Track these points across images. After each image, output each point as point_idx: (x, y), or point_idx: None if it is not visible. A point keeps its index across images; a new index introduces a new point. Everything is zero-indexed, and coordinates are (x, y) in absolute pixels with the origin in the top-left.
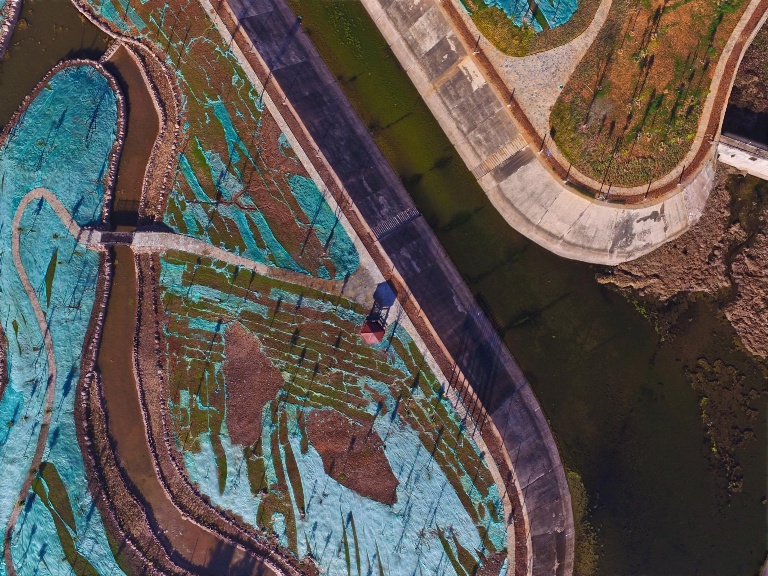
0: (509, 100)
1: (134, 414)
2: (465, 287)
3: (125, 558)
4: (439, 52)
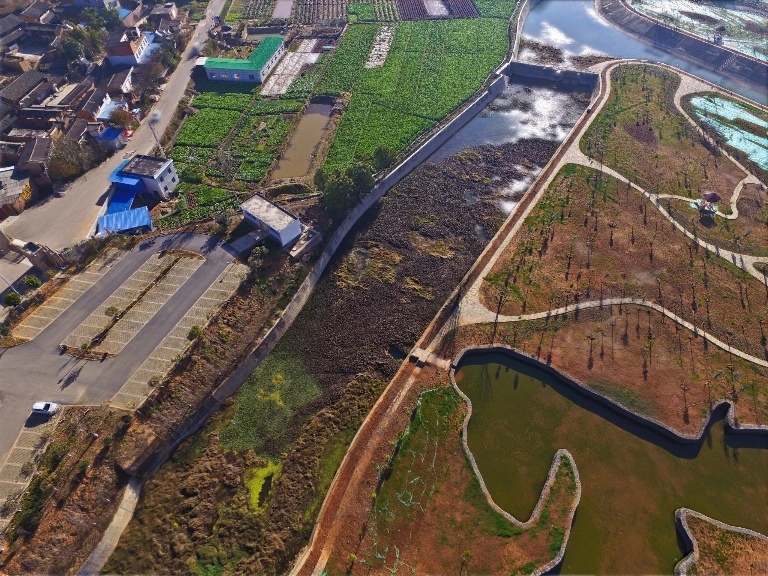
0: (704, 81)
1: None
2: (680, 56)
3: None
4: None
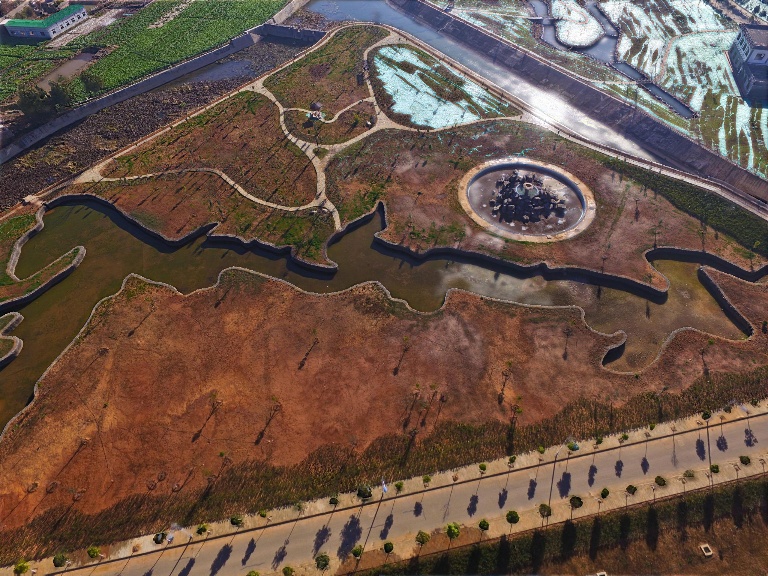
0: None
1: (530, 0)
2: (418, 22)
3: None
4: None
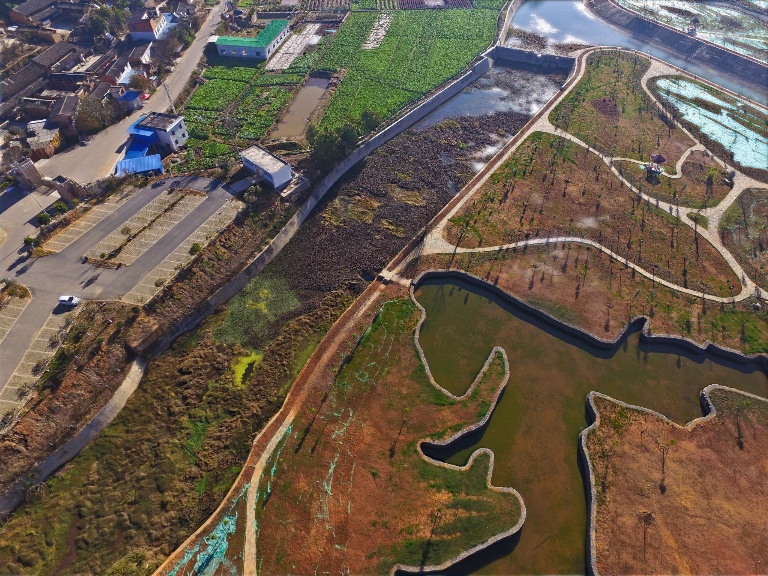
0: (672, 66)
1: None
2: None
3: (746, 2)
4: None
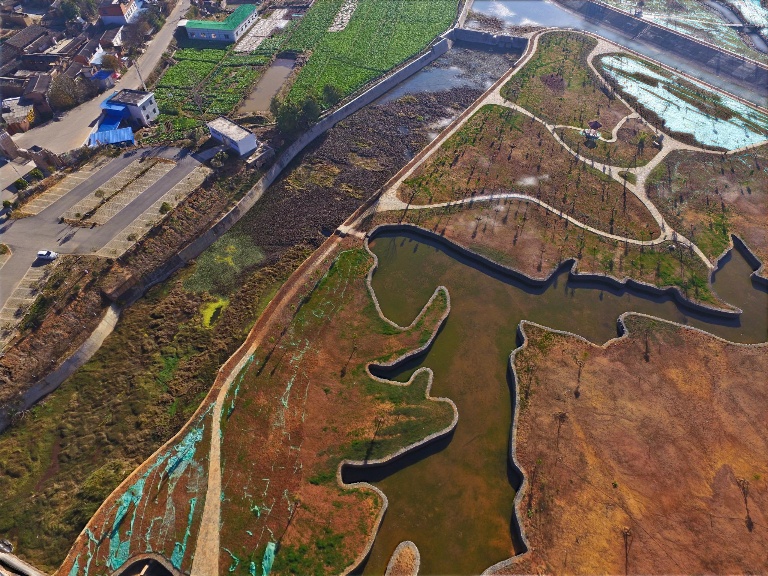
0: None
1: None
2: (605, 27)
3: None
4: None
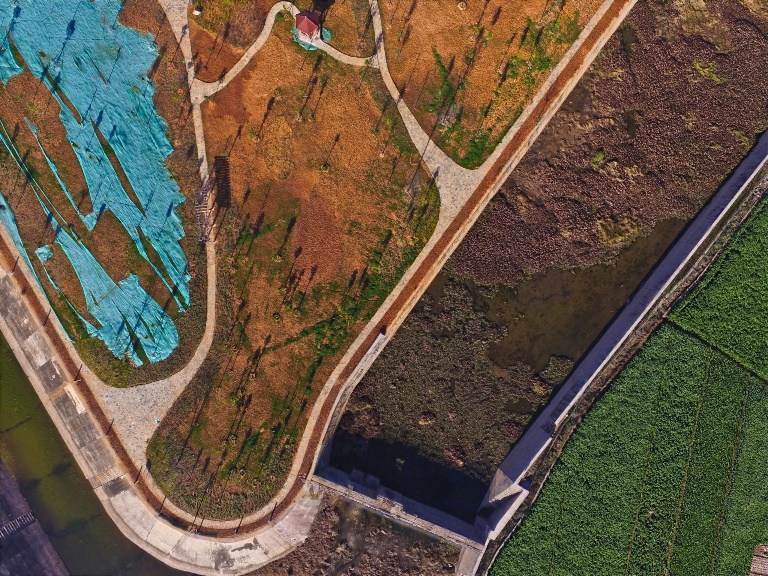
0: (107, 430)
1: None
2: None
3: None
4: (48, 371)
